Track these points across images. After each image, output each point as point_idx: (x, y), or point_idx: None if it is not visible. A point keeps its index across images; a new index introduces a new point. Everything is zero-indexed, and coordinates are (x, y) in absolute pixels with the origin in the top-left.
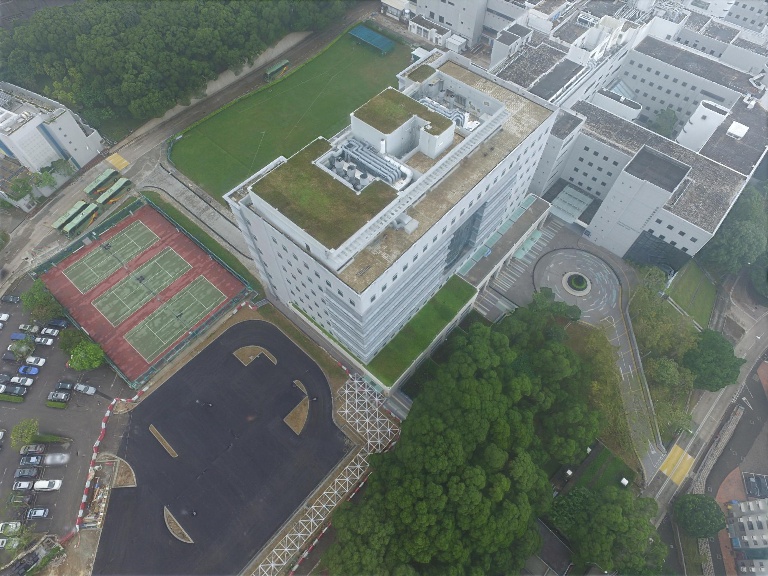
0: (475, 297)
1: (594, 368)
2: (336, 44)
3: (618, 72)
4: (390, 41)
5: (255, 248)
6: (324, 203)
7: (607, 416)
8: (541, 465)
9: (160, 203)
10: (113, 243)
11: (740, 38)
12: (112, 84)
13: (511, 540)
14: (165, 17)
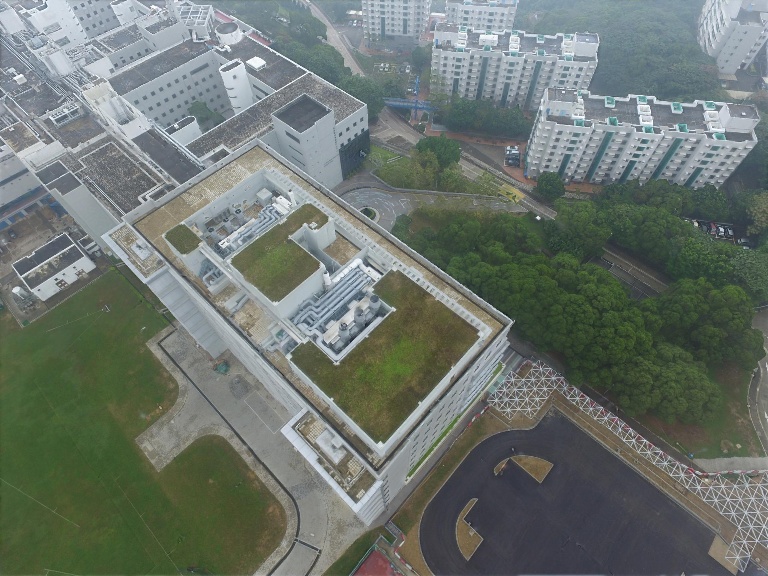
0: None
1: (457, 215)
2: None
3: None
4: None
5: None
6: (409, 347)
7: (502, 212)
8: None
9: None
10: None
11: None
12: None
13: None
14: None
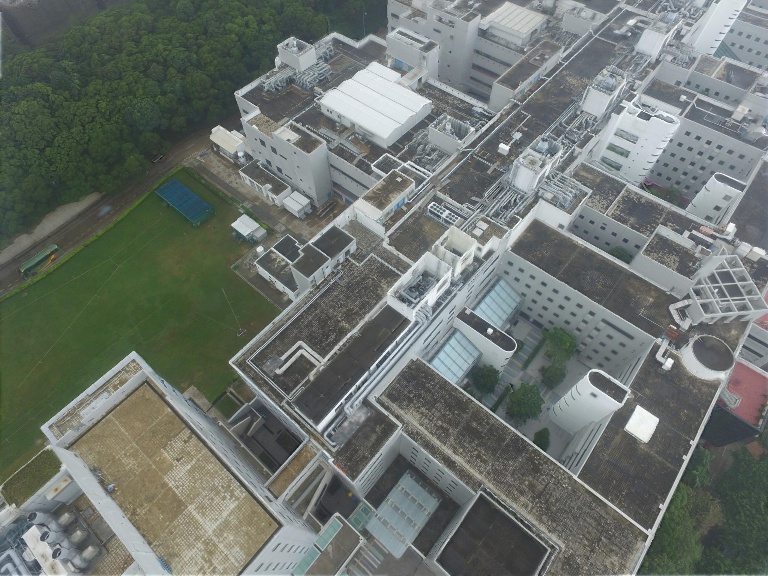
0: None
1: None
2: (139, 207)
3: (496, 270)
4: (207, 205)
5: None
6: None
7: None
8: None
9: None
10: None
11: (659, 234)
12: None
13: None
14: None
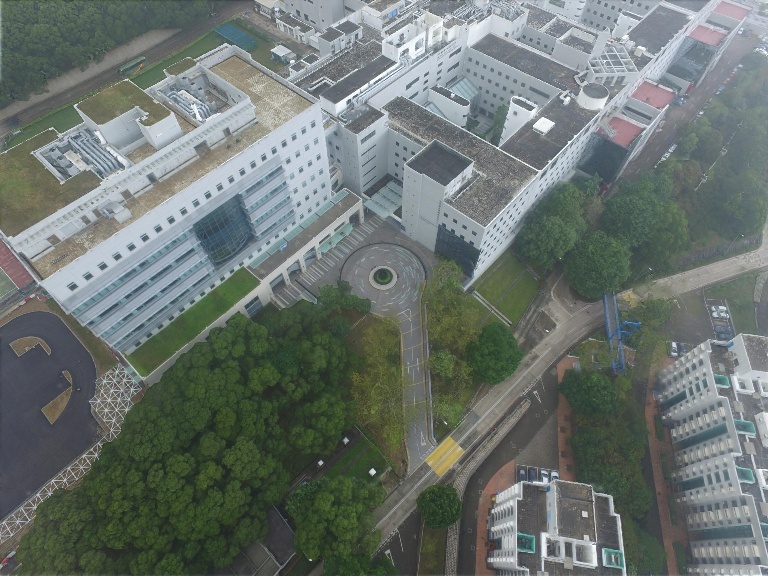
0: (261, 290)
1: (366, 360)
2: (201, 42)
3: (461, 69)
4: (252, 39)
5: None
6: (24, 192)
7: (358, 407)
8: (281, 455)
9: None
10: None
11: (573, 35)
12: None
13: (214, 527)
14: (1, 13)
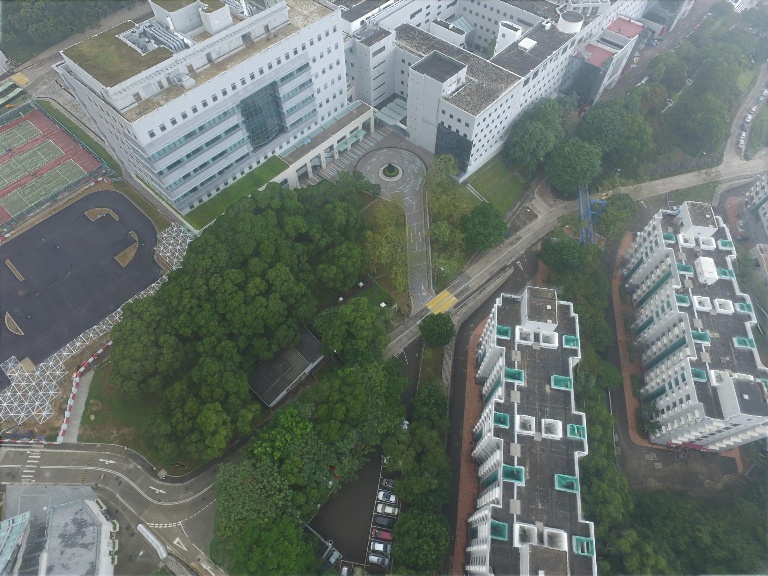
0: (289, 173)
1: (378, 226)
2: None
3: (458, 8)
4: None
5: (91, 118)
6: (114, 60)
7: (371, 253)
8: (310, 286)
9: (49, 109)
10: (3, 136)
11: None
12: (14, 11)
13: (260, 324)
14: None
